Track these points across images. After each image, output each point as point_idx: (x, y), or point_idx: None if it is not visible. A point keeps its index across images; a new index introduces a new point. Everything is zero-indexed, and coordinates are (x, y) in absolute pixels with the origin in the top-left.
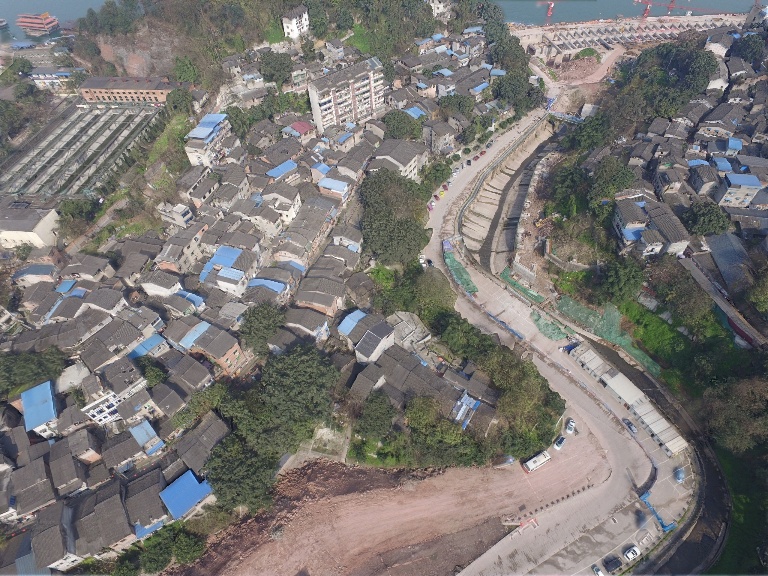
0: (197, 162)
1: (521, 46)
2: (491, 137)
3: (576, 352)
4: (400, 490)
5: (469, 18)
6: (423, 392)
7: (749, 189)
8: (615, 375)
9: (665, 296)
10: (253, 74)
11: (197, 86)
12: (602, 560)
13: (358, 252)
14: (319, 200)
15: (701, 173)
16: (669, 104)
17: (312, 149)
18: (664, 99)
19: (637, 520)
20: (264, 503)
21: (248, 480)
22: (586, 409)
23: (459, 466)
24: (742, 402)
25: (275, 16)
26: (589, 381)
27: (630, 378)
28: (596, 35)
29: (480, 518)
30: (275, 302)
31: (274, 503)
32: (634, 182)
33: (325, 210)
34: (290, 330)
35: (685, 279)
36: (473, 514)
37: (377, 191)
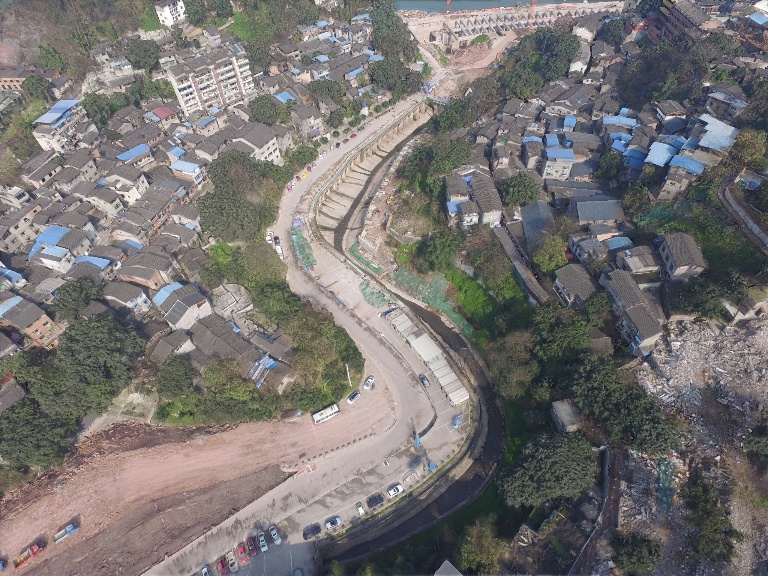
0: (48, 147)
1: (400, 32)
2: (364, 120)
3: (390, 316)
4: (189, 444)
5: (360, 6)
6: (226, 355)
7: (564, 162)
8: (420, 336)
9: (476, 262)
10: (120, 61)
11: (64, 74)
12: (367, 498)
13: (197, 230)
14: (166, 181)
15: (528, 148)
16: (524, 86)
17: (172, 133)
18: (518, 81)
19: (408, 462)
20: (54, 460)
21: (30, 438)
22: (388, 367)
23: (252, 421)
24: (513, 353)
25: (149, 4)
26: (398, 342)
27: (446, 340)
28: (494, 22)
29: (260, 466)
30: (99, 277)
31: (69, 461)
32: (472, 159)
33: (170, 191)
34: (107, 302)
35: (492, 246)
36: (254, 463)
37: (222, 172)
